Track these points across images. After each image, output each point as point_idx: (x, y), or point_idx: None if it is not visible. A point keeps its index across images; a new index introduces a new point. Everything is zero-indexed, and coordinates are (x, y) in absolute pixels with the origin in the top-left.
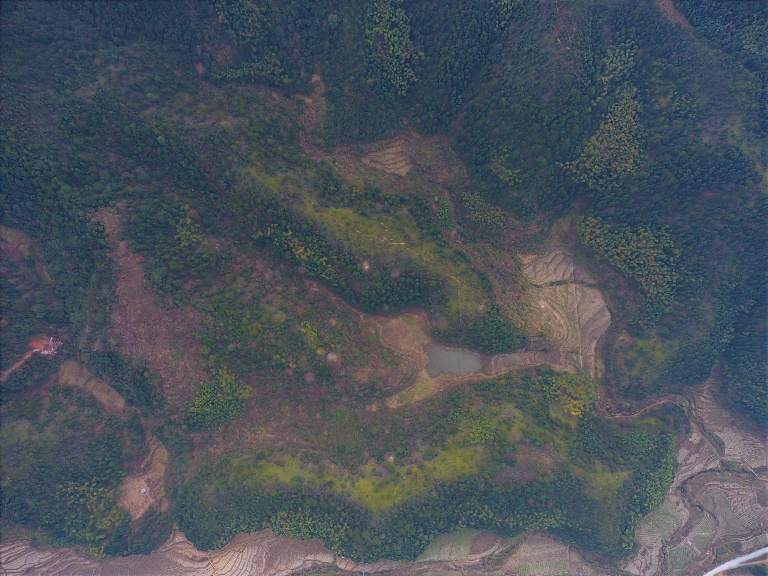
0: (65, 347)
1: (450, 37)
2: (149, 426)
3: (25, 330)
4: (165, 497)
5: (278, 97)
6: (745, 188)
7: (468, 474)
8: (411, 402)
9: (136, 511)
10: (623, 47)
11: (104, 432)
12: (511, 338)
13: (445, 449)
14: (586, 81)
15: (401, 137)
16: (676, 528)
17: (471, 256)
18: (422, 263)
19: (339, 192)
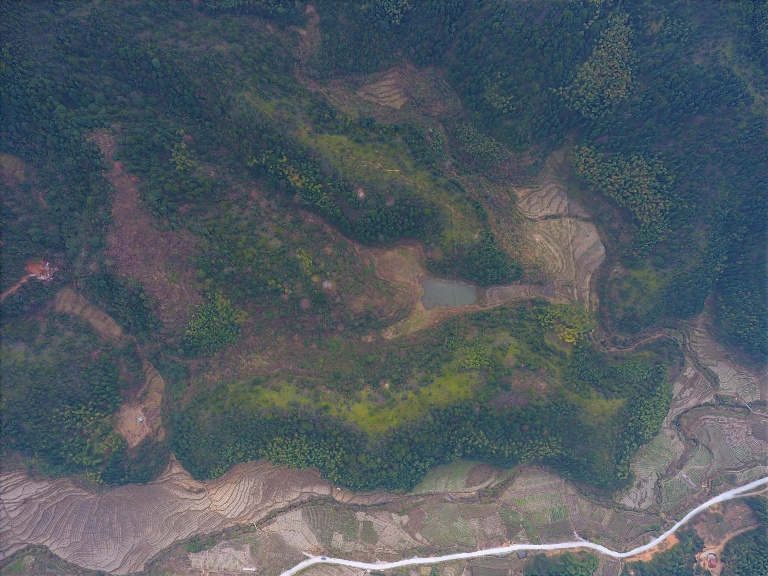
0: (61, 273)
1: None
2: (145, 353)
3: (21, 253)
4: (162, 426)
5: (273, 29)
6: (737, 109)
7: (463, 398)
8: (407, 333)
9: (133, 439)
10: None
11: (100, 357)
12: (506, 267)
13: (440, 375)
14: (578, 3)
15: (395, 69)
16: (671, 461)
17: (465, 186)
18: (417, 191)
19: (334, 121)
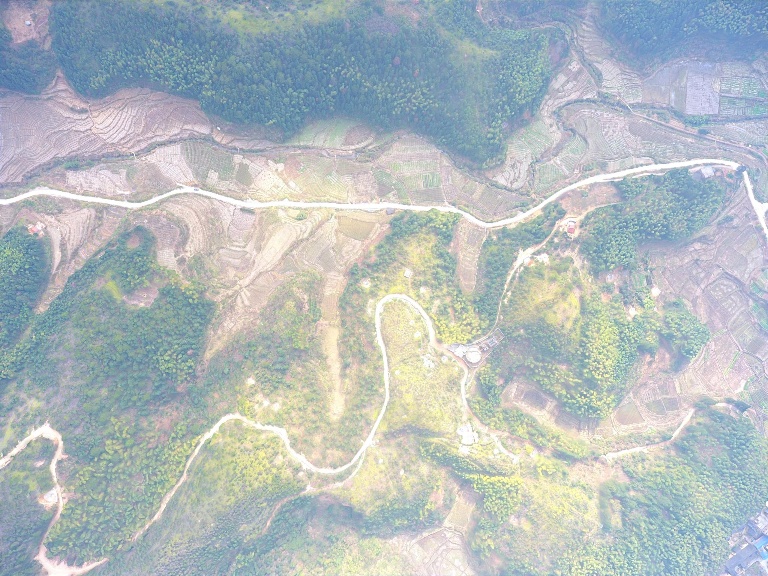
0: None
1: None
2: None
3: None
4: (48, 29)
5: None
6: None
7: (336, 17)
8: None
9: (18, 36)
10: None
11: None
12: None
13: (319, 2)
14: None
15: None
16: (547, 147)
17: None
18: None
19: None
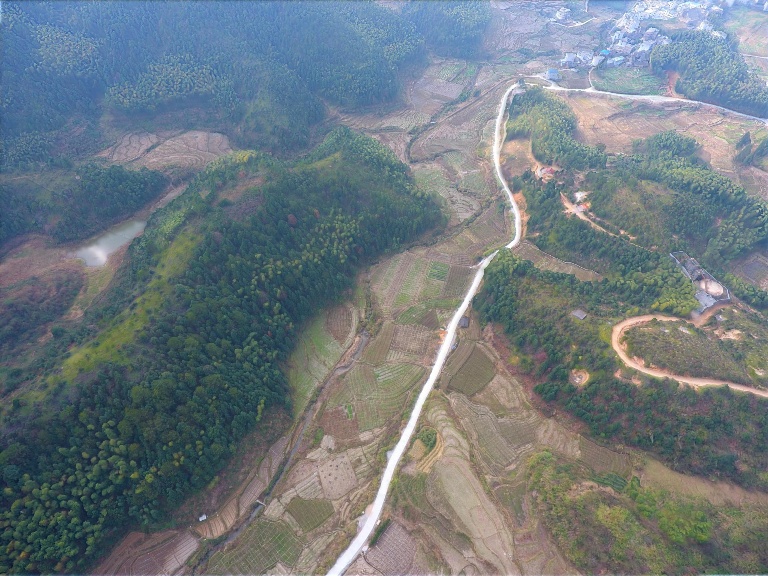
0: None
1: None
2: None
3: None
4: None
5: None
6: None
7: None
8: None
9: None
10: (4, 8)
11: None
12: (134, 173)
13: (157, 262)
14: None
15: None
16: (445, 175)
17: None
18: None
19: None
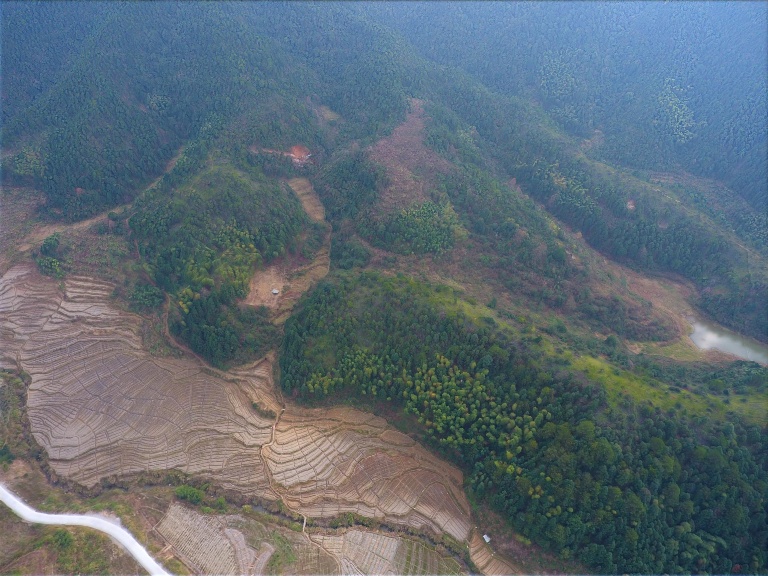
0: (313, 165)
1: (736, 113)
2: None
3: None
4: None
5: None
6: None
7: None
8: None
9: (254, 299)
10: None
11: None
12: None
13: (742, 392)
14: None
15: (671, 174)
16: None
17: None
18: (699, 223)
19: None
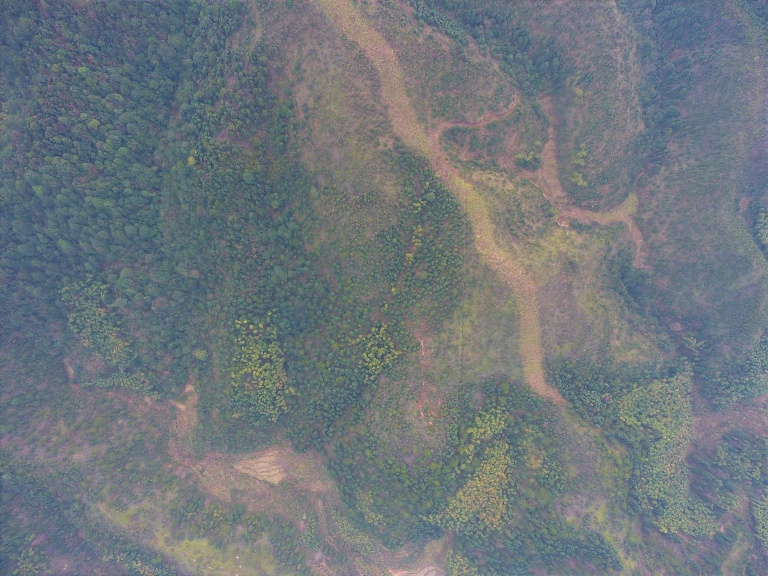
0: None
1: (318, 385)
2: None
3: None
4: None
5: (151, 402)
6: (604, 575)
7: None
8: None
9: None
10: (493, 413)
11: None
12: None
13: None
14: (449, 452)
15: (275, 448)
16: None
17: None
18: None
19: (199, 515)
